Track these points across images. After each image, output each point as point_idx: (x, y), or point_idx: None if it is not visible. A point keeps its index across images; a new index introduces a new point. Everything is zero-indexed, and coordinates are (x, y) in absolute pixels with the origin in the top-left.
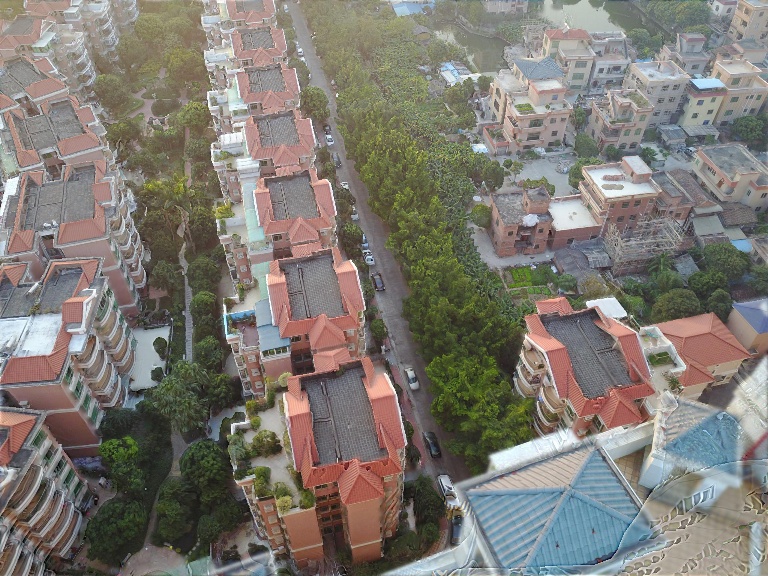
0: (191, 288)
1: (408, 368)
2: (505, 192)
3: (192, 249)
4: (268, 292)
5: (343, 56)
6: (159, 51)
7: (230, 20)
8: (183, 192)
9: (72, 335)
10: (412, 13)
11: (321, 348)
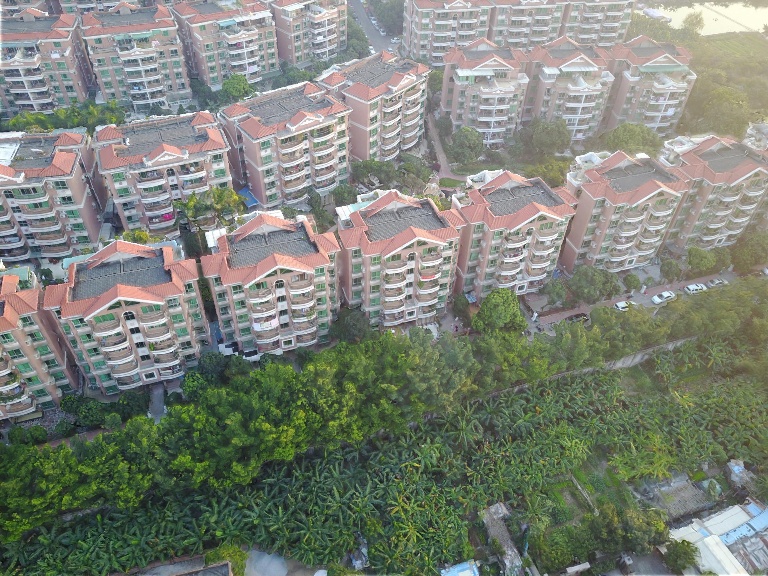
0: None
1: None
2: None
3: None
4: None
5: (635, 323)
6: None
7: None
8: (190, 208)
9: None
10: None
11: None
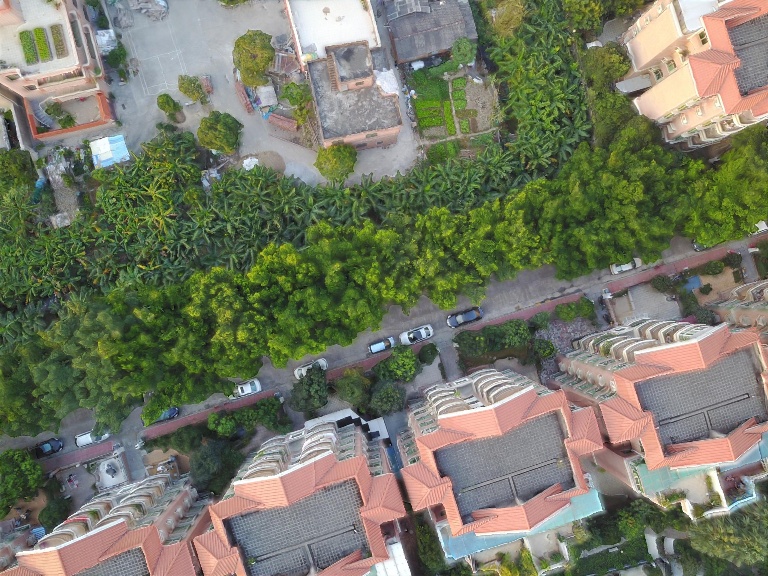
0: None
1: (613, 270)
2: None
3: None
4: None
5: None
6: None
7: None
8: None
9: None
10: None
11: None
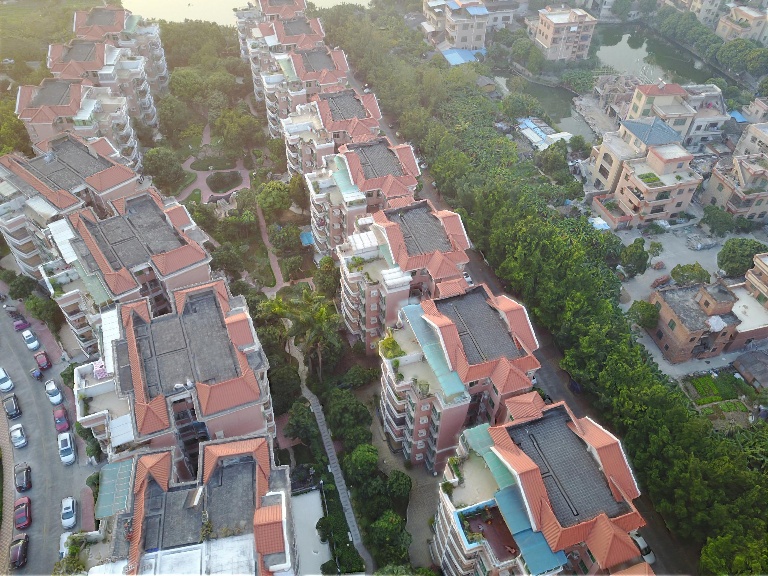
0: (331, 432)
1: None
2: (643, 277)
3: (316, 376)
4: (520, 484)
5: (422, 117)
6: (201, 111)
7: (299, 80)
8: (325, 318)
9: (273, 573)
10: (468, 61)
11: (613, 565)
